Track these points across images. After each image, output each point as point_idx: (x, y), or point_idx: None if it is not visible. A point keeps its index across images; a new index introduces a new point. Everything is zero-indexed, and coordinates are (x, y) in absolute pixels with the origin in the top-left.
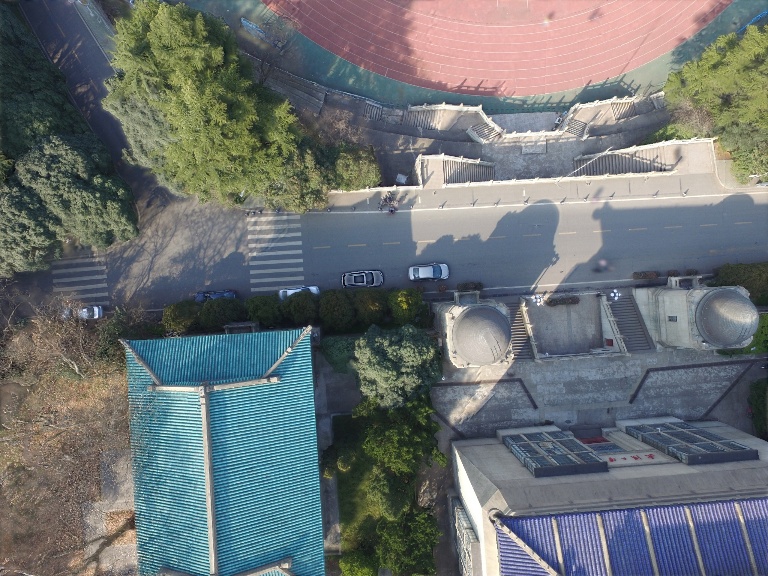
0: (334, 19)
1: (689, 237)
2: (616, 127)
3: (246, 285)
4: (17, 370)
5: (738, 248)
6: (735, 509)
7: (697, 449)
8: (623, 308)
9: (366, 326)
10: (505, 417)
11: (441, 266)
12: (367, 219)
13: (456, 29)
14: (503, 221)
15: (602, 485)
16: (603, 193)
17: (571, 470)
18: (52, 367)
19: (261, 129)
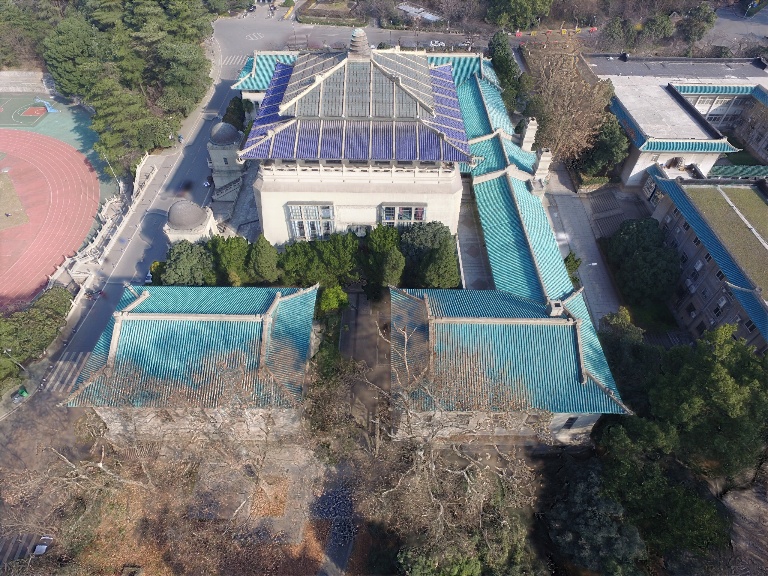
0: None
1: (197, 167)
2: None
3: None
4: (45, 574)
5: None
6: None
7: None
8: None
9: None
10: None
11: None
12: (97, 308)
13: (5, 278)
14: (143, 238)
15: None
16: (152, 195)
17: None
18: (72, 567)
19: None
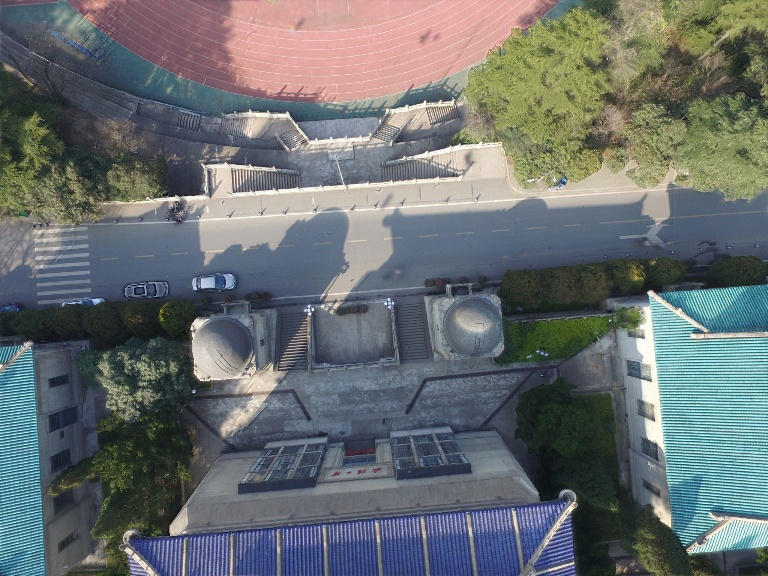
0: (152, 28)
1: (481, 243)
2: (431, 132)
3: (33, 298)
4: None
5: (531, 253)
6: (375, 528)
7: (416, 463)
8: (411, 316)
9: (140, 338)
10: (277, 429)
11: (225, 276)
12: (154, 230)
13: (276, 35)
14: (292, 230)
15: (292, 502)
16: (393, 200)
17: (275, 486)
18: None
19: (15, 142)
